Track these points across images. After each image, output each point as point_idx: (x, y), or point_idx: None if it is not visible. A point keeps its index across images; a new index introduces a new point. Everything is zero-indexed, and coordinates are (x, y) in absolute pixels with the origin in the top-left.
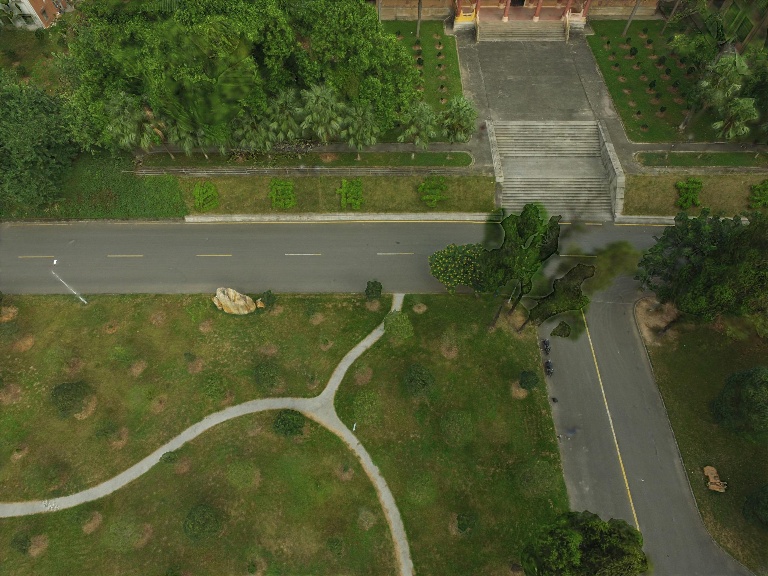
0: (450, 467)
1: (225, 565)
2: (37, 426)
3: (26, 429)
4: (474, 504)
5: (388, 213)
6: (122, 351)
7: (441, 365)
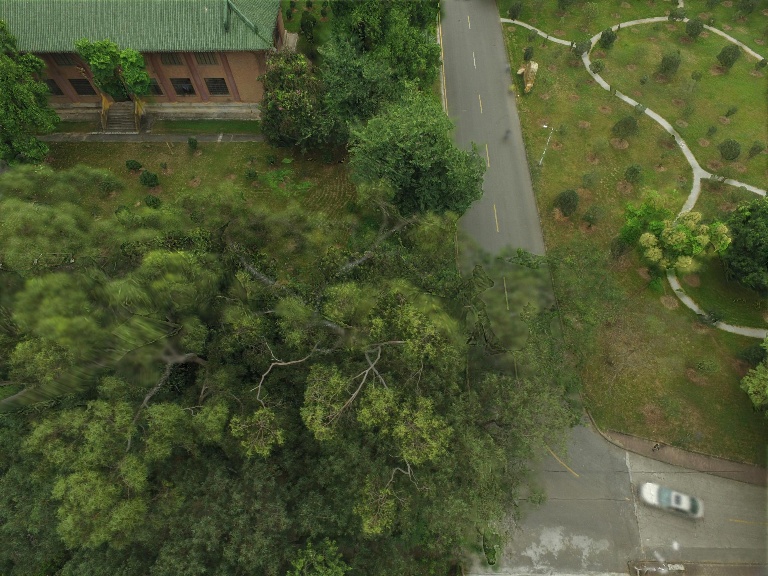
0: (600, 7)
1: (677, 72)
2: (641, 164)
3: (645, 170)
4: (614, 1)
5: (436, 20)
6: (591, 104)
7: (545, 7)
